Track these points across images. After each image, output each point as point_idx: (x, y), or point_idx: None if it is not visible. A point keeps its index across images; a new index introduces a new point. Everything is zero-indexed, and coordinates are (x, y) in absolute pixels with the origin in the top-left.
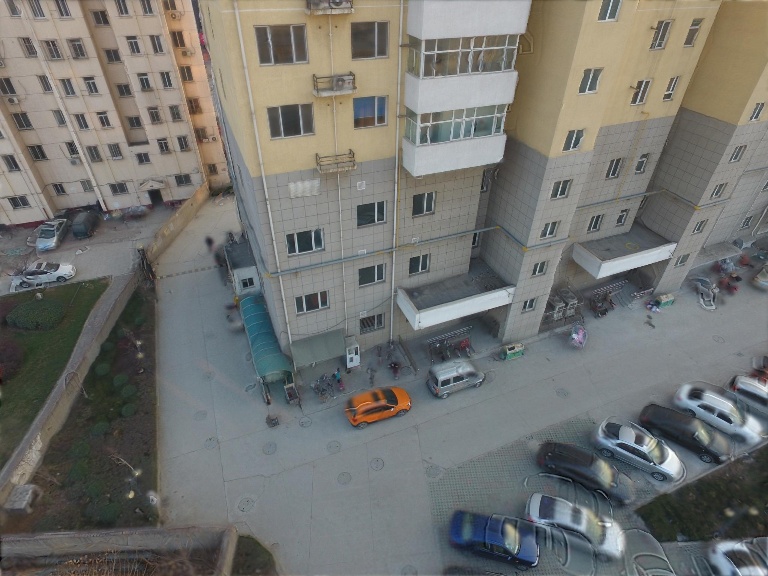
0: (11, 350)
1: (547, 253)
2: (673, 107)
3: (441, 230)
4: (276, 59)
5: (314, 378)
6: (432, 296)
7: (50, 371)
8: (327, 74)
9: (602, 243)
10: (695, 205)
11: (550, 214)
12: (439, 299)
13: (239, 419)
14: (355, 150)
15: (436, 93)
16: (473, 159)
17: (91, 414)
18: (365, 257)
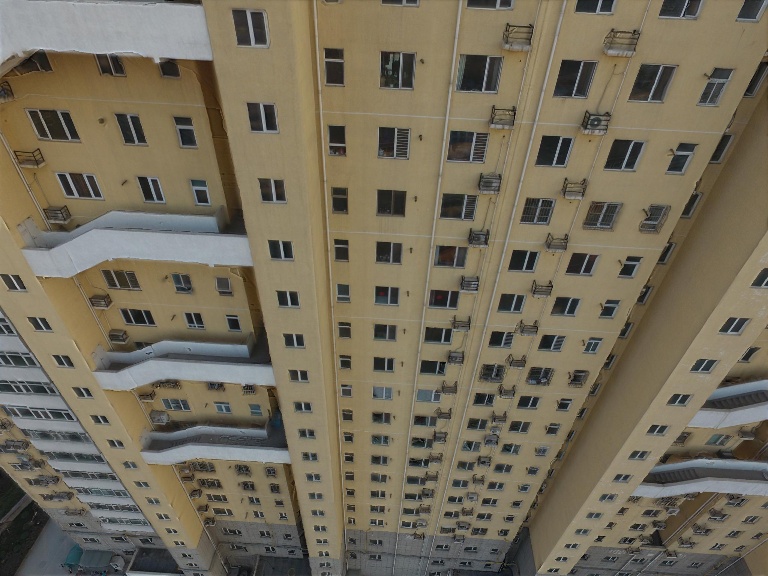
0: (6, 481)
1: (199, 572)
2: (291, 523)
3: (153, 534)
4: (37, 484)
5: (92, 571)
6: (150, 559)
7: (14, 499)
8: (60, 491)
9: (278, 560)
10: (311, 575)
11: (186, 561)
12: (151, 564)
13: (54, 575)
14: (85, 508)
15: (100, 513)
16: (136, 530)
17: (4, 542)
18: (111, 534)
